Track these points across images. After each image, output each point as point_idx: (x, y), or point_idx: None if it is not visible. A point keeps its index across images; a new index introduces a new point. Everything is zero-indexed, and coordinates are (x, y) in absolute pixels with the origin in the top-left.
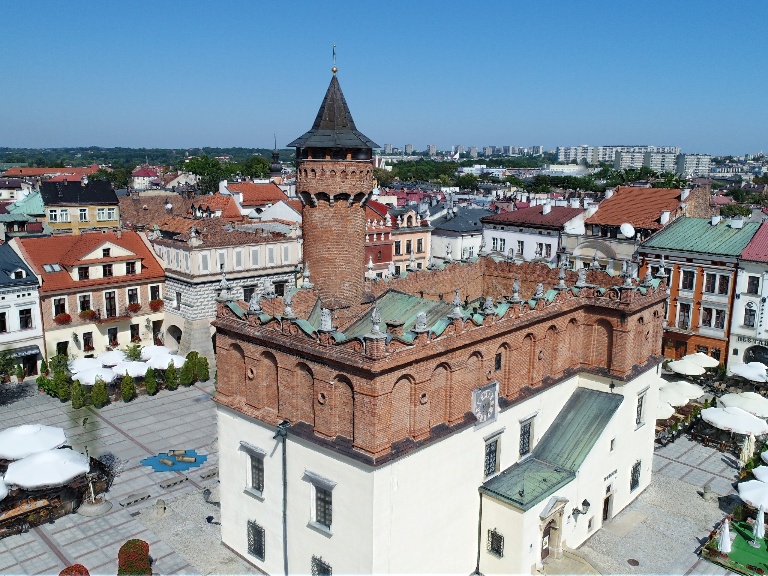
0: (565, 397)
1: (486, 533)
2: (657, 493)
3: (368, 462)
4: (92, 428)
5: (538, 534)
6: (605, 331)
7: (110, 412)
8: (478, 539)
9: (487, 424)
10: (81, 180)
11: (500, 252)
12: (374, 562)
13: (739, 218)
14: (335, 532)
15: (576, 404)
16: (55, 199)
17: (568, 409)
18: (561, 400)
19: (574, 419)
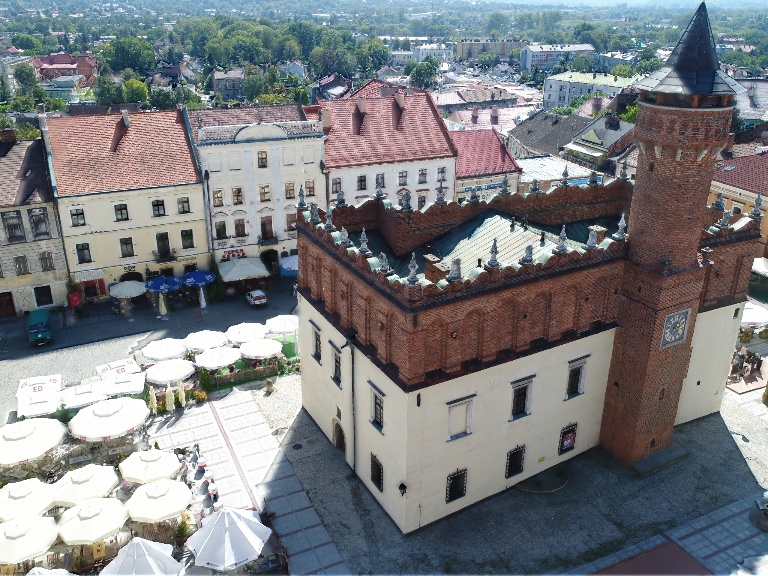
0: None
1: None
2: None
3: None
4: None
5: None
6: None
7: None
8: None
9: None
10: None
11: None
12: None
13: None
14: None
15: None
16: None
17: None
18: None
19: None
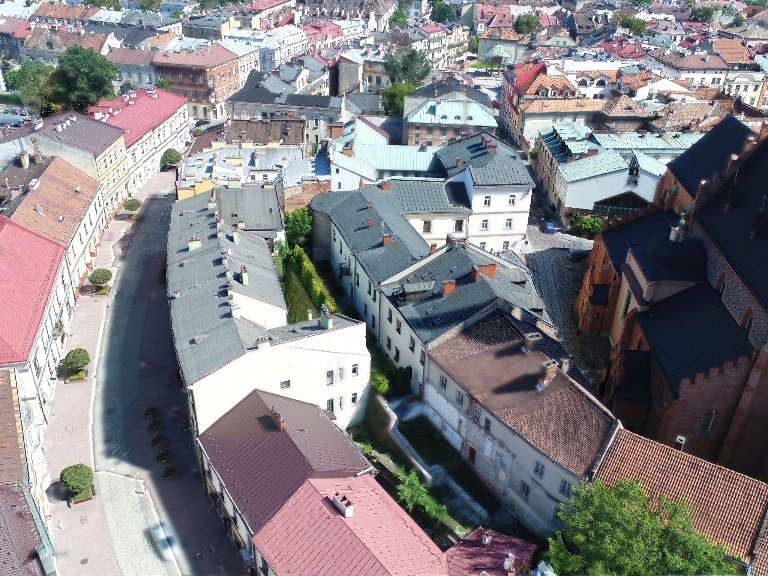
0: None
1: None
2: None
3: None
4: None
5: None
6: None
7: None
8: None
9: None
10: None
11: None
12: None
13: None
14: None
15: None
16: (486, 105)
17: None
18: None
19: None
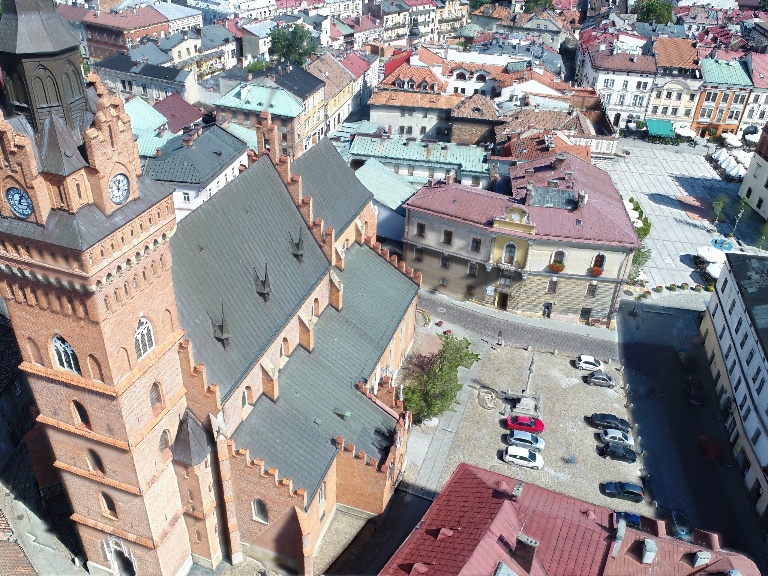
0: None
1: None
2: None
3: None
4: (671, 245)
5: None
6: None
7: (654, 236)
8: None
9: None
10: (288, 67)
11: (610, 88)
12: None
13: (734, 61)
14: None
15: None
16: (299, 93)
17: None
18: None
19: None
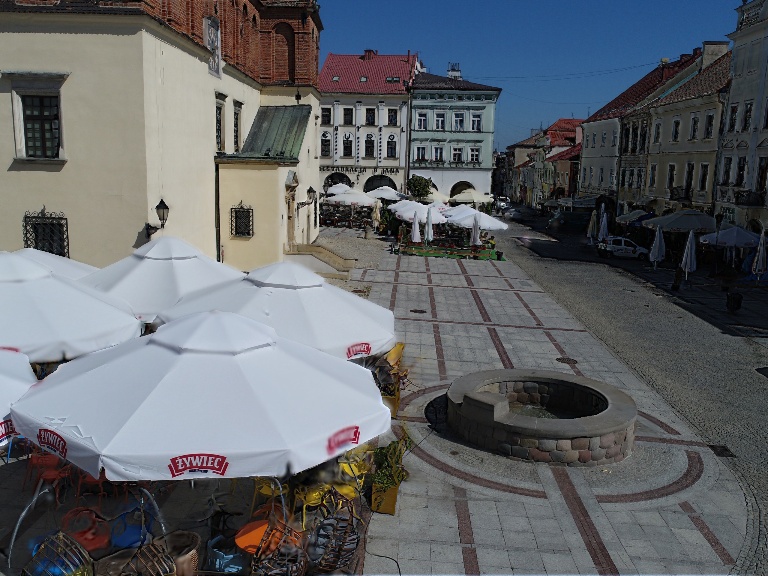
0: (254, 109)
1: (228, 214)
2: (328, 239)
3: (134, 12)
4: None
5: (284, 208)
6: (284, 38)
7: None
8: (216, 228)
9: (215, 76)
10: None
11: None
12: (148, 177)
13: None
14: (70, 156)
15: (266, 117)
16: None
17: (260, 121)
18: (253, 109)
19: (271, 126)
